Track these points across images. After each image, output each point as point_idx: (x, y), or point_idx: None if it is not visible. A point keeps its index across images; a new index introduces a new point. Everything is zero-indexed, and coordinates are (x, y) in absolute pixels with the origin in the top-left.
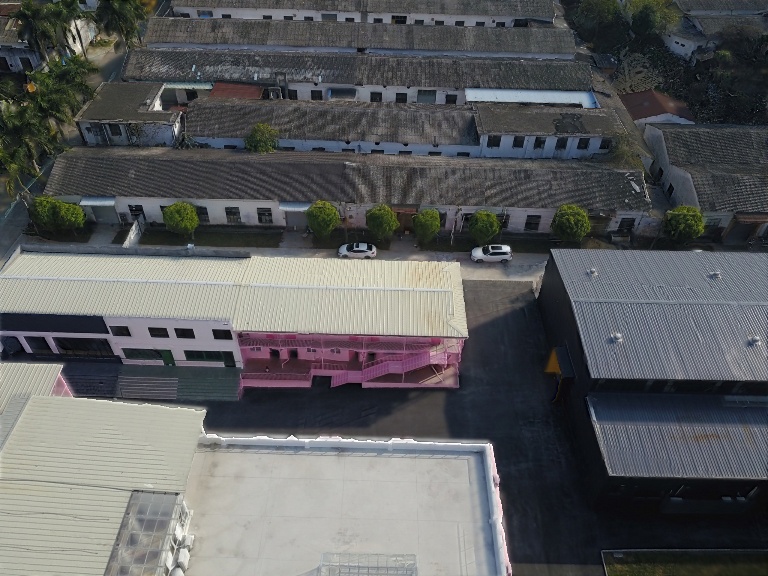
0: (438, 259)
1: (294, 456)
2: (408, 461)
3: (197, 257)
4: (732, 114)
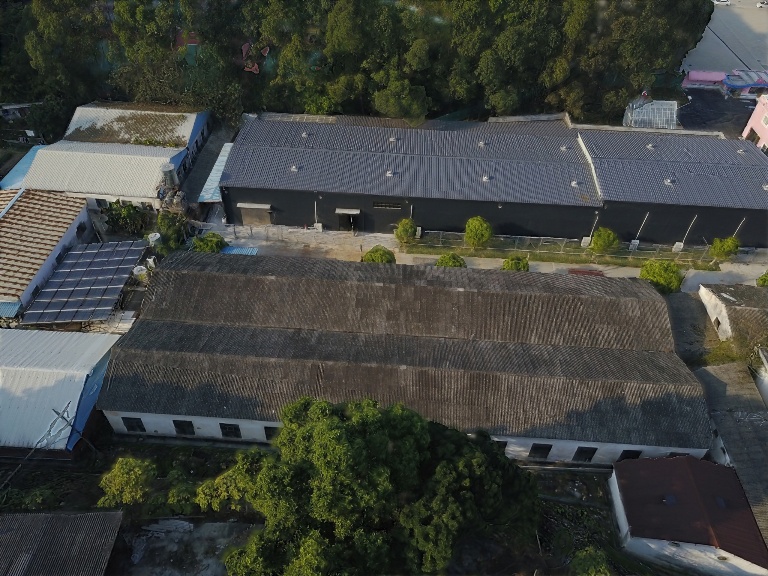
0: None
1: None
2: None
3: None
4: None
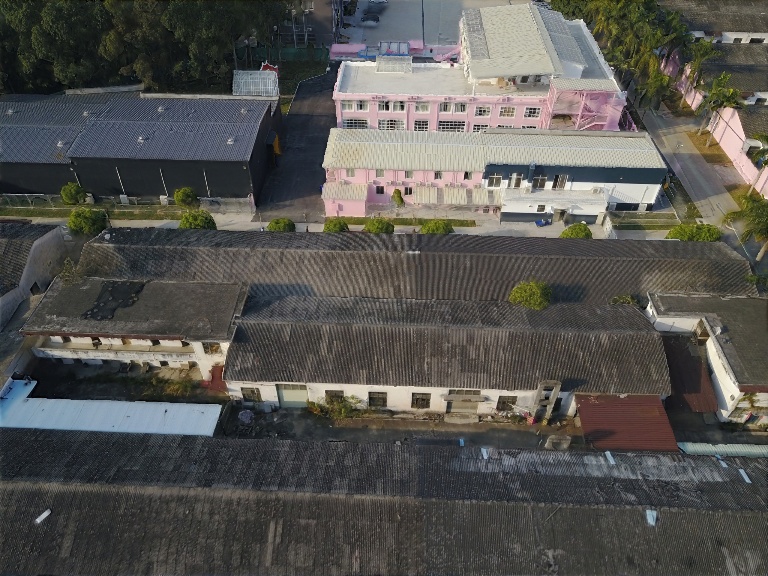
0: None
1: None
2: None
3: None
4: None
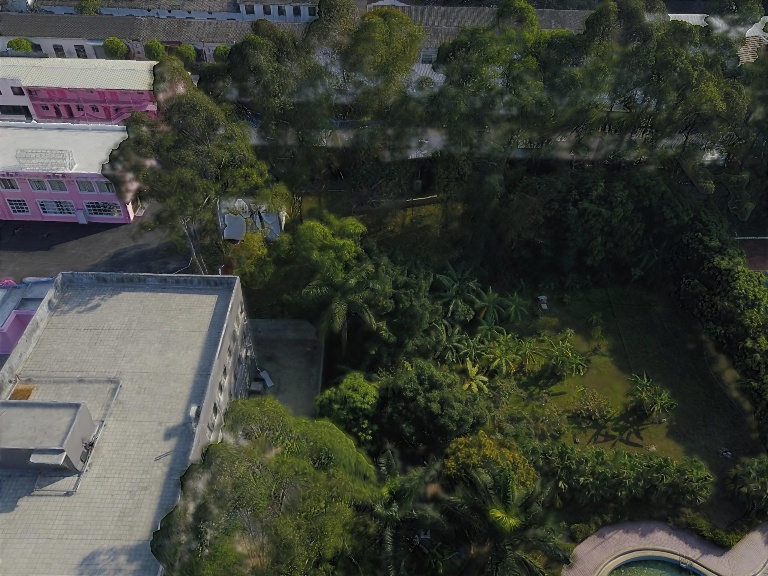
0: (194, 78)
1: (34, 131)
2: (98, 133)
3: (14, 57)
4: (447, 4)
